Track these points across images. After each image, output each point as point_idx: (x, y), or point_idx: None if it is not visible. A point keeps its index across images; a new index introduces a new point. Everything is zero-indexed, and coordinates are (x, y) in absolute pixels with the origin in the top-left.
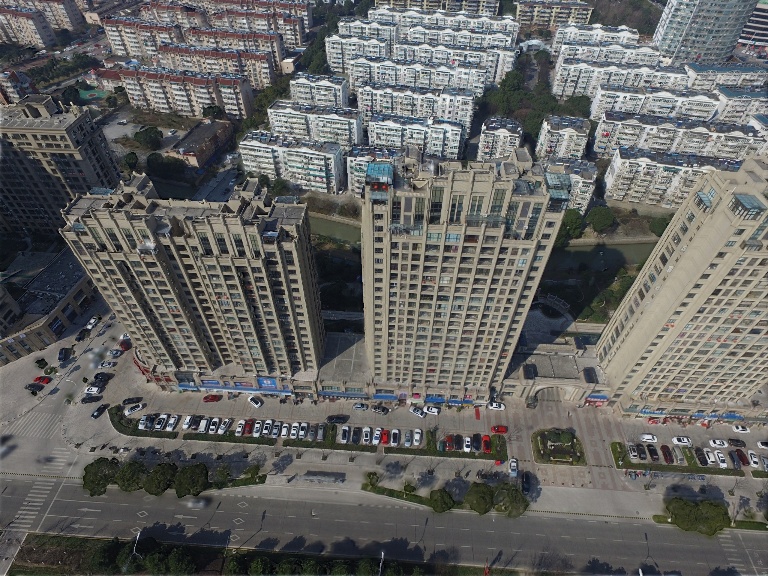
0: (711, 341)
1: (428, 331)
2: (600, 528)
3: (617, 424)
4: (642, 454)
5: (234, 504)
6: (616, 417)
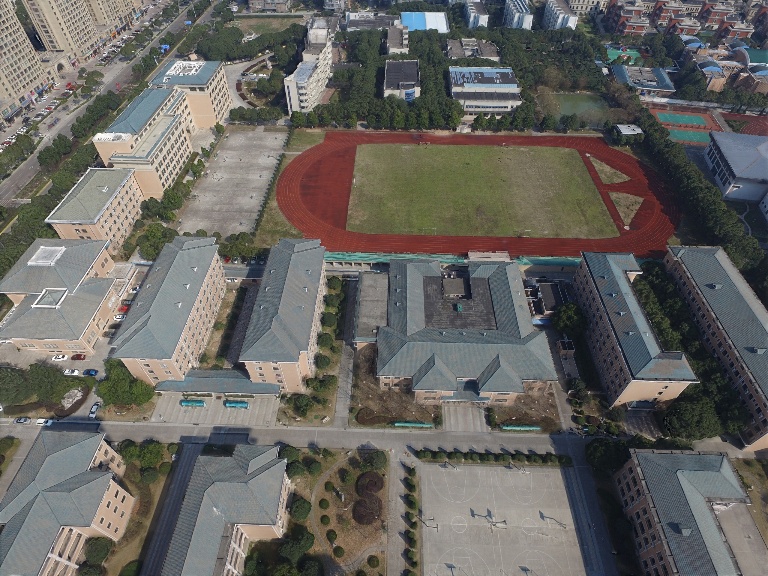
0: (63, 0)
1: (0, 42)
2: (122, 73)
3: (88, 64)
4: (103, 60)
5: (48, 144)
6: (85, 64)
